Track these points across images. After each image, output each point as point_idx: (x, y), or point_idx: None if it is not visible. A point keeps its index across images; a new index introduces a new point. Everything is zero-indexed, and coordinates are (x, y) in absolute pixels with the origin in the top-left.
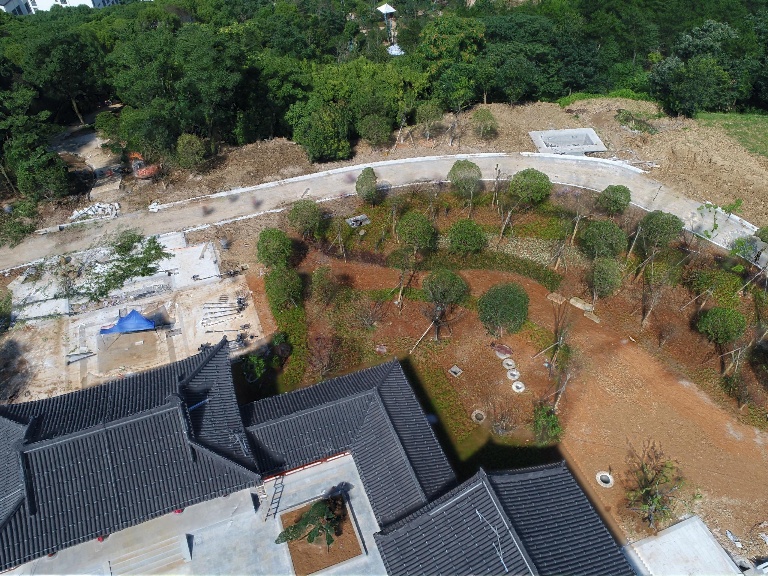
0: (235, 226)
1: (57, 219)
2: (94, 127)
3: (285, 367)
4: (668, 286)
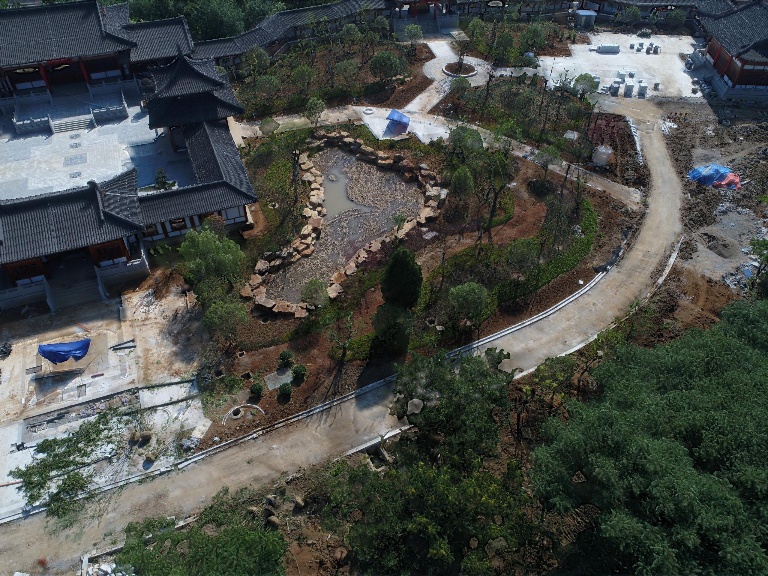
0: None
1: None
2: None
3: None
4: None
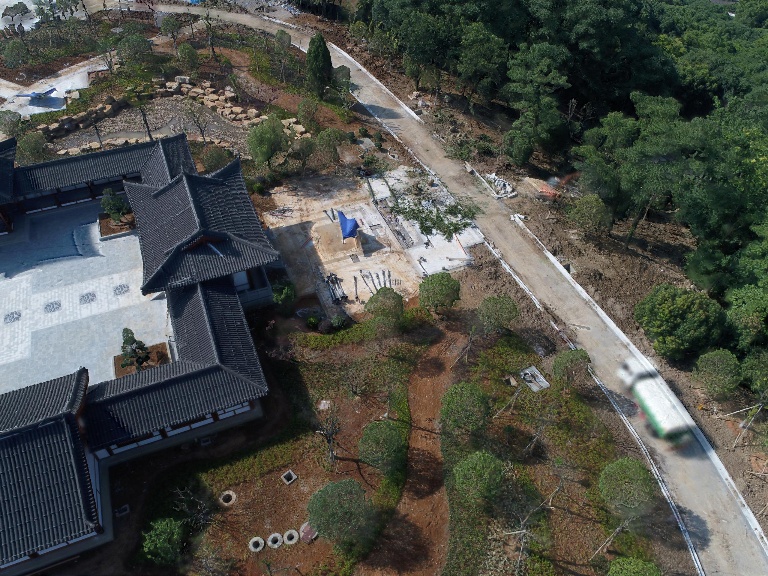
0: (501, 275)
1: (483, 168)
2: None
3: (311, 333)
4: None
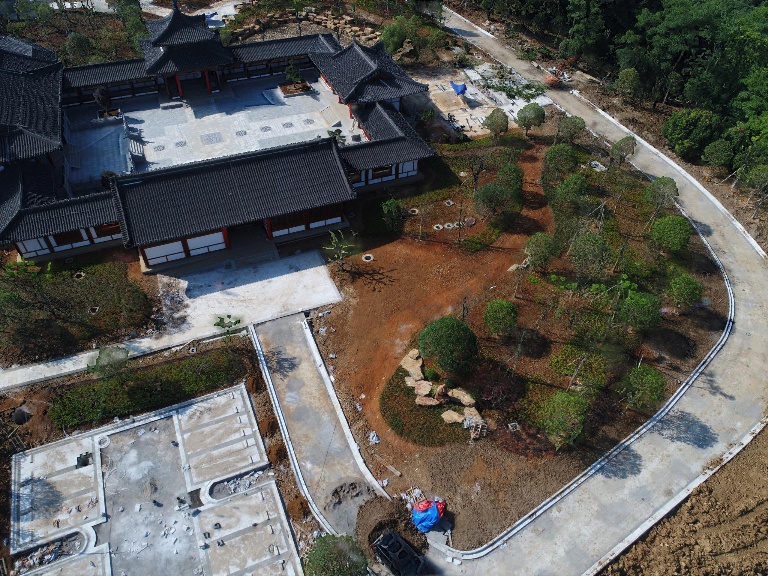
0: None
1: (546, 65)
2: None
3: (444, 144)
4: None
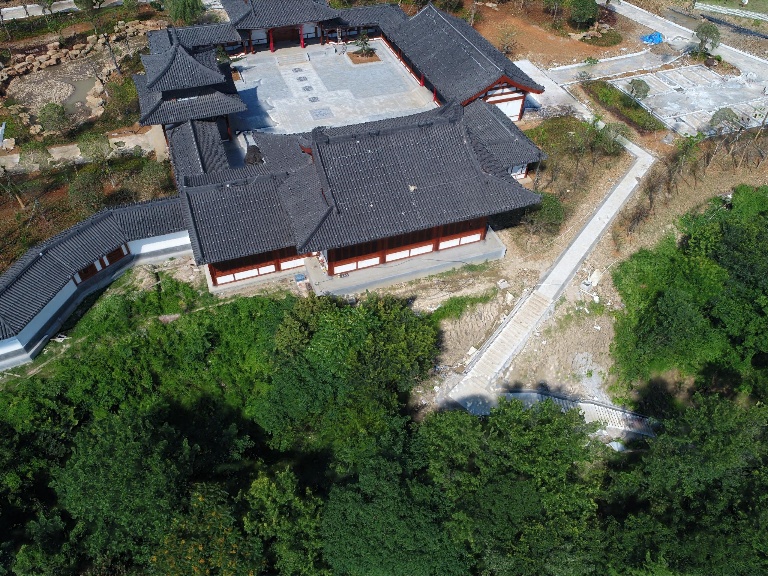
0: None
1: None
2: None
3: None
4: (537, 1)
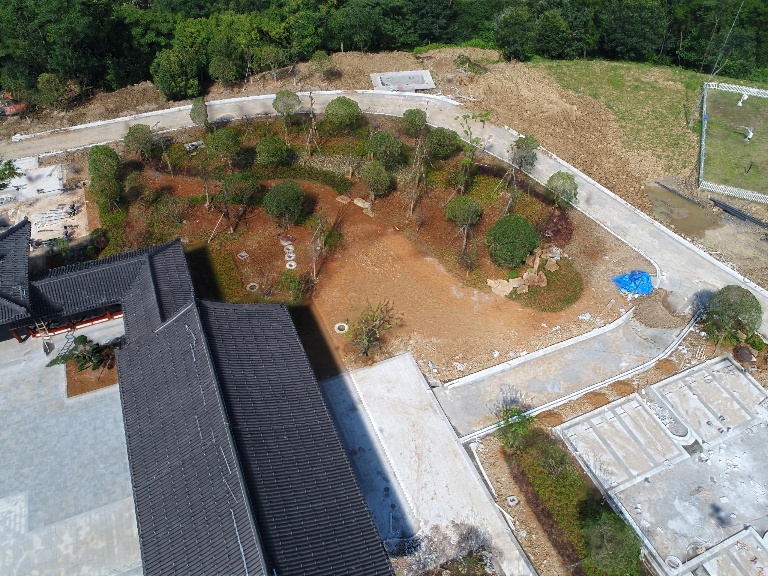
0: (85, 151)
1: None
2: (2, 86)
3: (100, 255)
4: (441, 189)
